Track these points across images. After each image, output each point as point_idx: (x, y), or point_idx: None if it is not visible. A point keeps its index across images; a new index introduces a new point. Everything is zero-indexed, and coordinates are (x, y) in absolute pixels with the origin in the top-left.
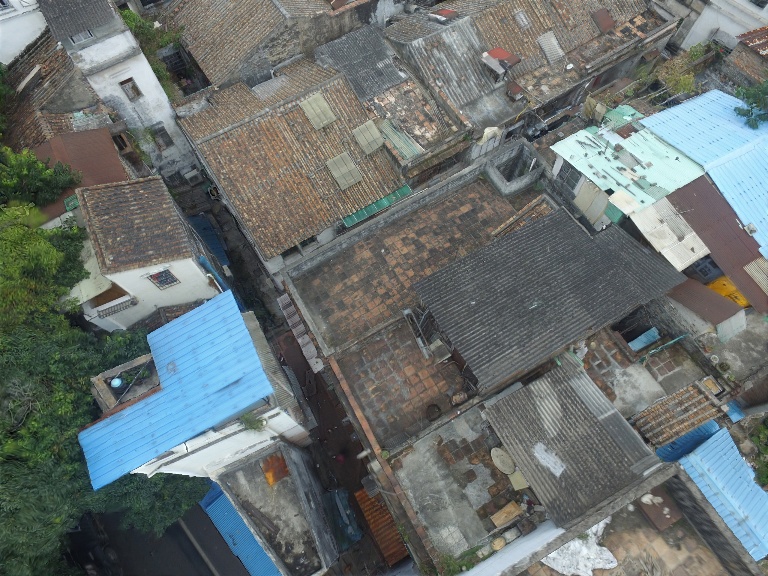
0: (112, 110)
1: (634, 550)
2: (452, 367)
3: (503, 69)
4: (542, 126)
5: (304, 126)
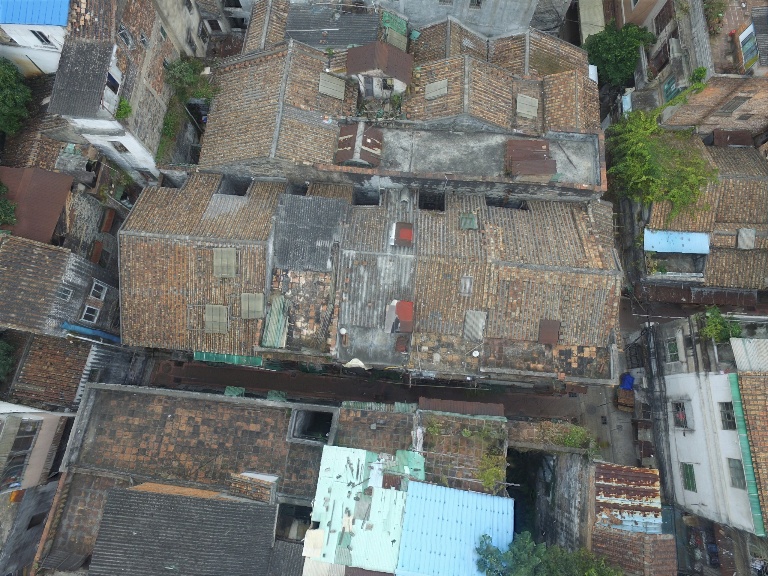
0: (97, 155)
1: None
2: None
3: (391, 330)
4: (430, 375)
5: (209, 266)
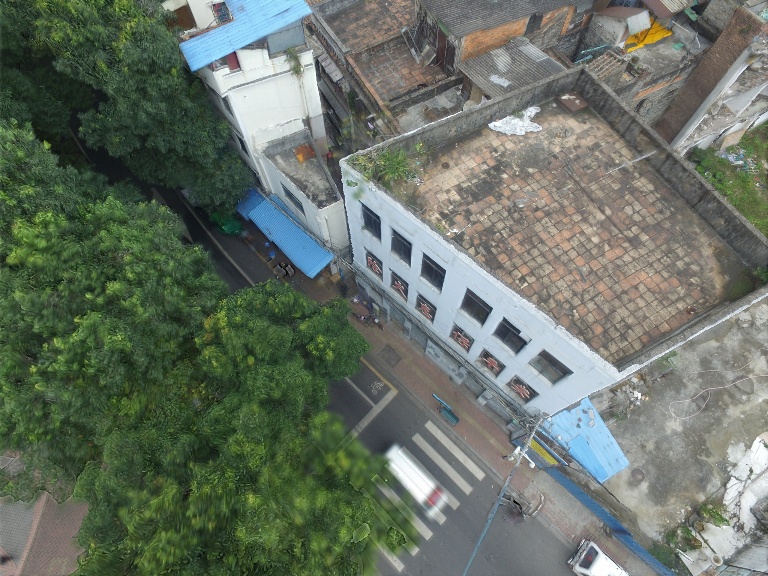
0: None
1: (554, 124)
2: (437, 68)
3: None
4: None
5: None
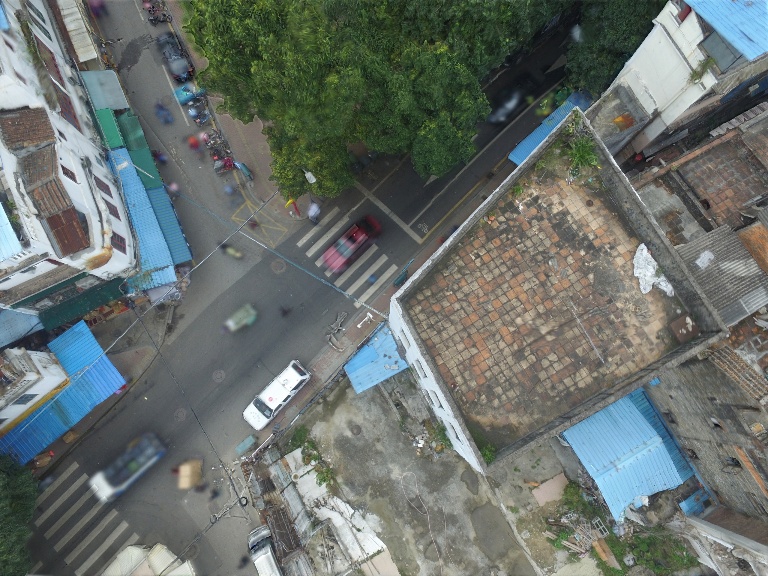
0: None
1: (652, 307)
2: (738, 223)
3: None
4: None
5: None
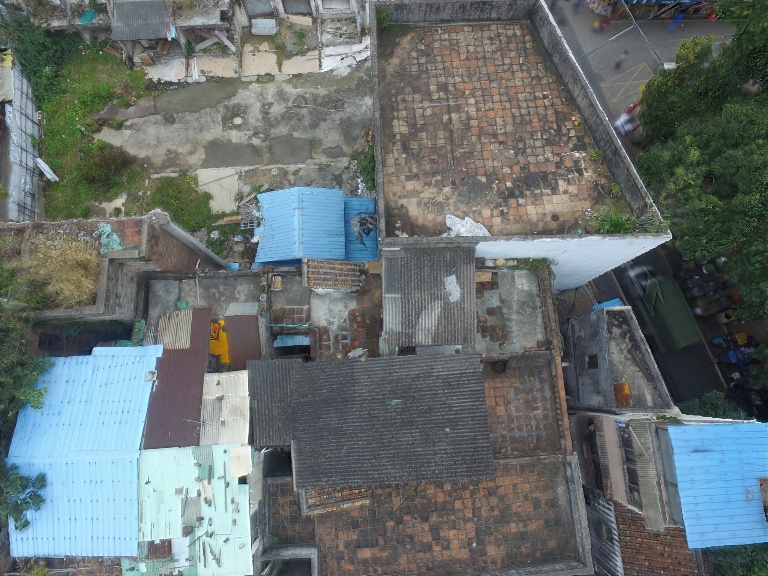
0: None
1: (430, 217)
2: None
3: None
4: None
5: None
